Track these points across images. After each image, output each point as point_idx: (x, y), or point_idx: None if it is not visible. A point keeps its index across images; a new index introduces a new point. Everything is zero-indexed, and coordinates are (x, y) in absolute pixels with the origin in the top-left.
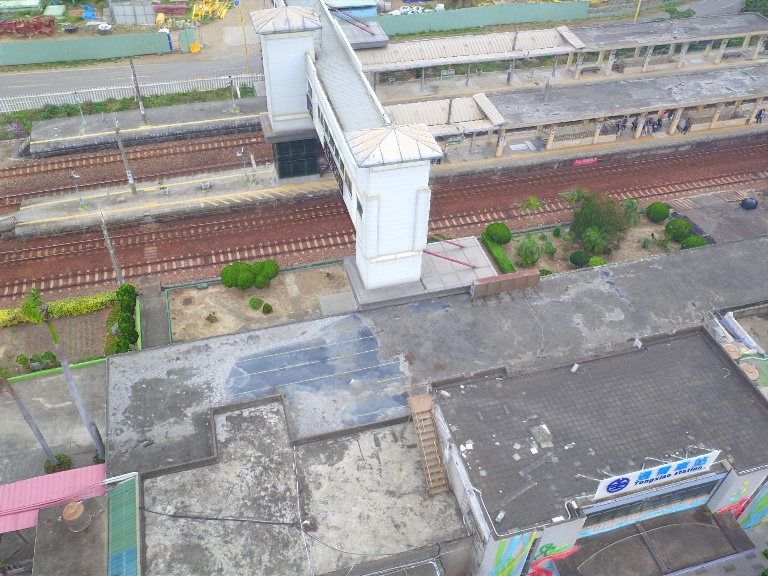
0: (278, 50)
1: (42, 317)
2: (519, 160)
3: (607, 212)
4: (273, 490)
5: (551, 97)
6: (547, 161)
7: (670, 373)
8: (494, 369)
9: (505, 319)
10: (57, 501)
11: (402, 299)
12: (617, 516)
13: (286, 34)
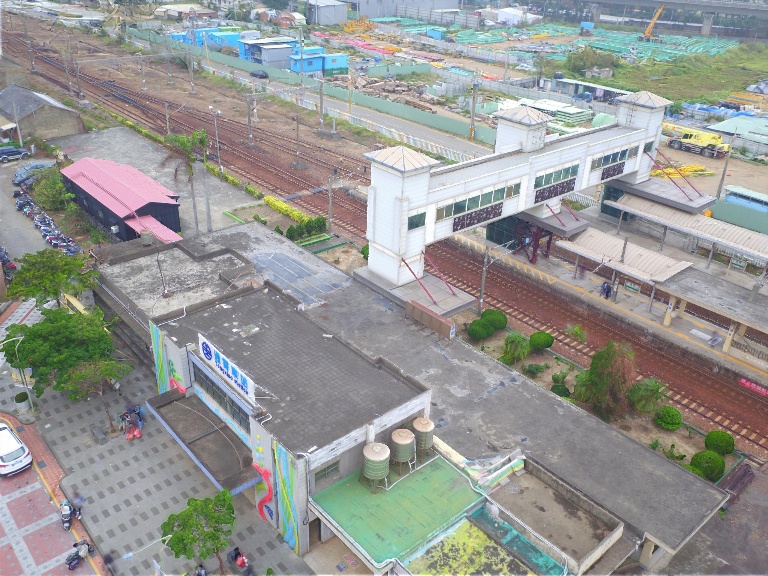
0: (505, 133)
1: (198, 142)
2: (677, 338)
3: (604, 363)
4: (186, 280)
5: (760, 302)
6: (705, 356)
7: (358, 383)
8: (297, 299)
9: (400, 336)
10: (161, 239)
11: (374, 285)
12: (217, 401)
13: (511, 123)
